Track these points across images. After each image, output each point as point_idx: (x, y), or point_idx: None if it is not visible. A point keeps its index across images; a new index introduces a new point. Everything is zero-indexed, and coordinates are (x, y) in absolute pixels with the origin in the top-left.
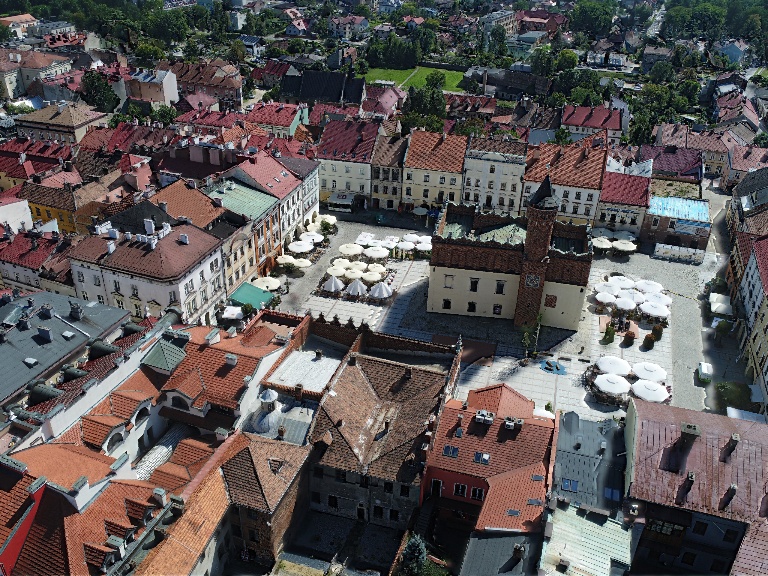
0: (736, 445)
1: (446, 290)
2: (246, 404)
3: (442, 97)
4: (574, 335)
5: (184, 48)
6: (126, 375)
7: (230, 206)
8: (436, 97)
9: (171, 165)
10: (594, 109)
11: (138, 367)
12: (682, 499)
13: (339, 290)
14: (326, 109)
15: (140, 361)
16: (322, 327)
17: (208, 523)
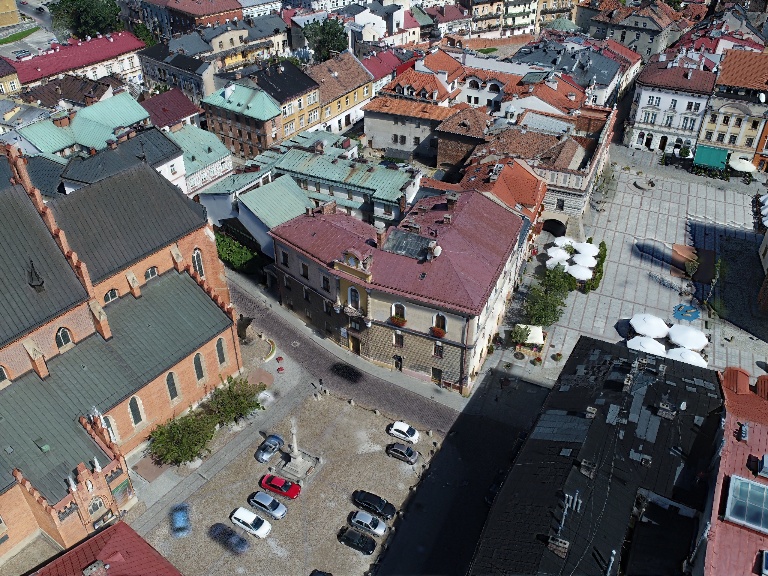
0: None
1: None
2: None
3: None
4: (766, 343)
5: None
6: (516, 72)
7: None
8: None
9: None
10: None
11: None
12: None
13: None
14: None
15: (528, 73)
16: None
17: (428, 115)
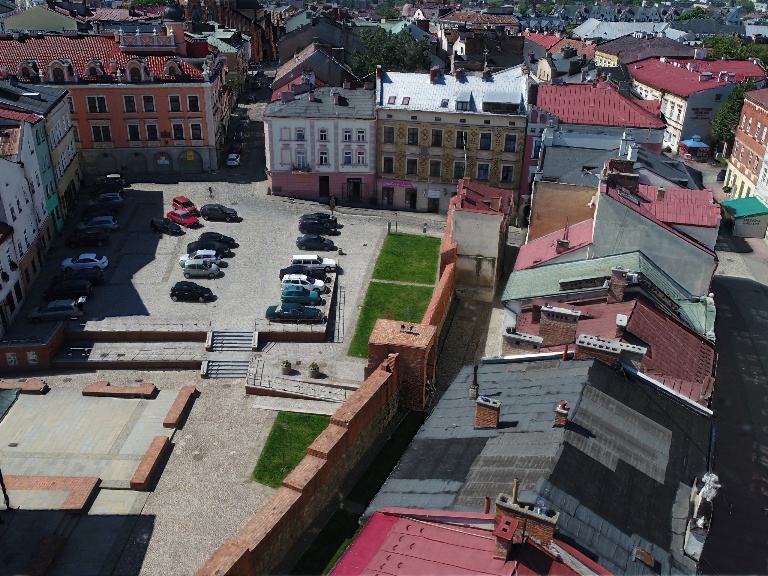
0: None
1: None
2: None
3: None
4: None
5: None
6: None
7: None
8: None
9: None
10: None
11: None
12: None
13: None
14: None
15: None
16: None
17: None
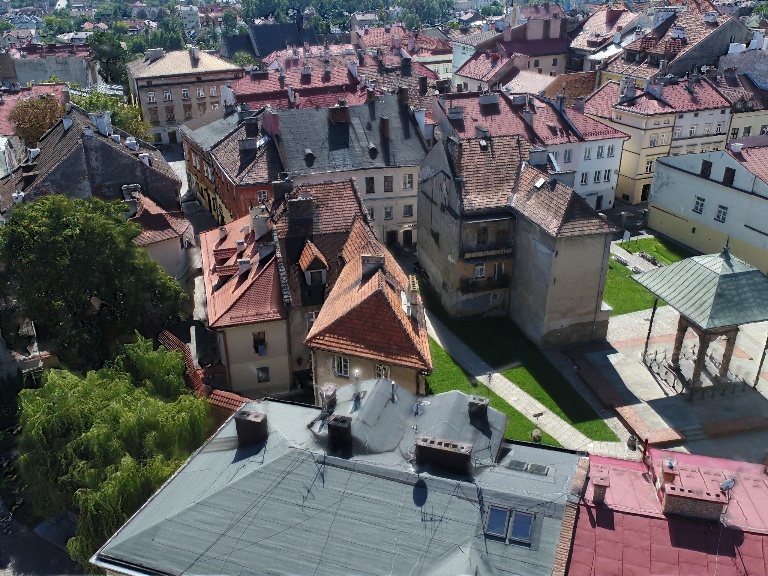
0: None
1: None
2: None
3: None
4: None
5: None
6: None
7: None
8: None
9: (515, 48)
10: None
11: None
12: None
13: None
14: None
15: None
16: None
17: None
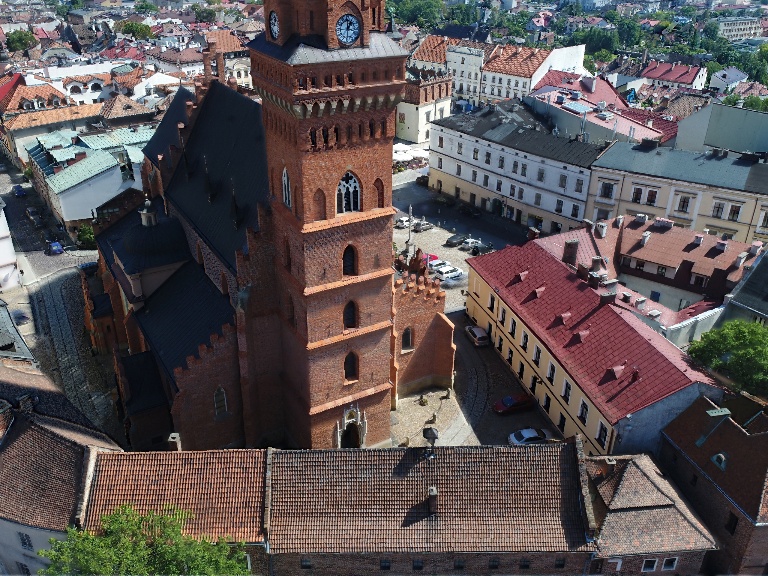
0: None
1: None
2: (141, 91)
3: None
4: (413, 144)
5: None
6: (101, 72)
7: None
8: None
9: None
10: (676, 65)
11: (110, 72)
12: None
13: None
14: None
15: (112, 69)
16: None
17: (81, 115)
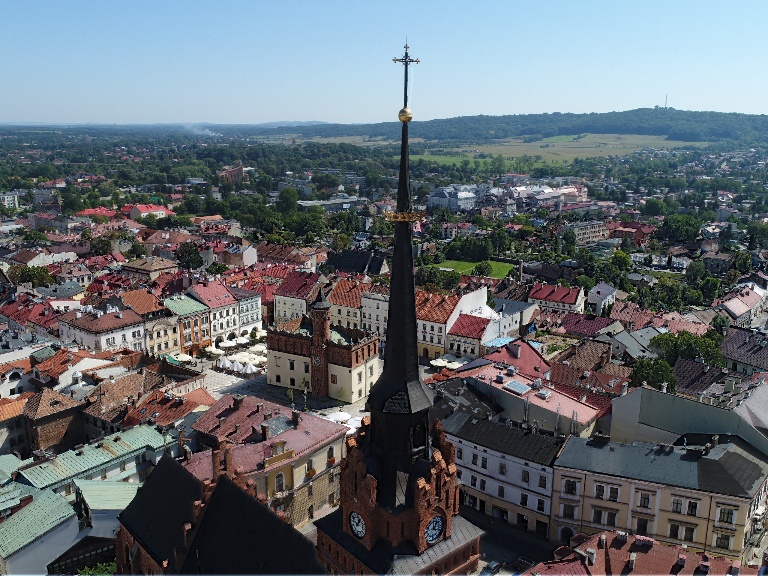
0: (259, 409)
1: (277, 368)
2: (66, 379)
3: (438, 272)
4: (347, 405)
5: (304, 239)
6: (19, 358)
7: (171, 307)
8: (433, 272)
9: (172, 289)
10: (558, 287)
11: (29, 356)
12: (213, 430)
13: (226, 367)
14: (343, 275)
15: (31, 354)
16: (148, 359)
17: (2, 417)
